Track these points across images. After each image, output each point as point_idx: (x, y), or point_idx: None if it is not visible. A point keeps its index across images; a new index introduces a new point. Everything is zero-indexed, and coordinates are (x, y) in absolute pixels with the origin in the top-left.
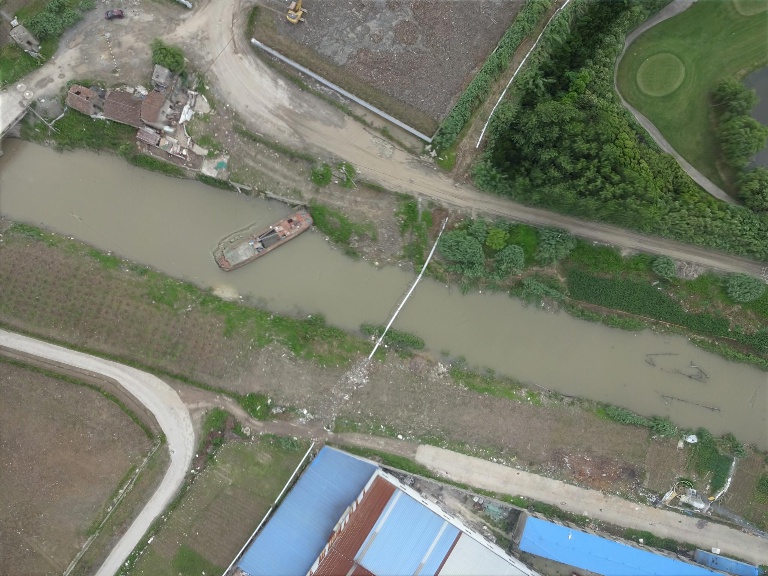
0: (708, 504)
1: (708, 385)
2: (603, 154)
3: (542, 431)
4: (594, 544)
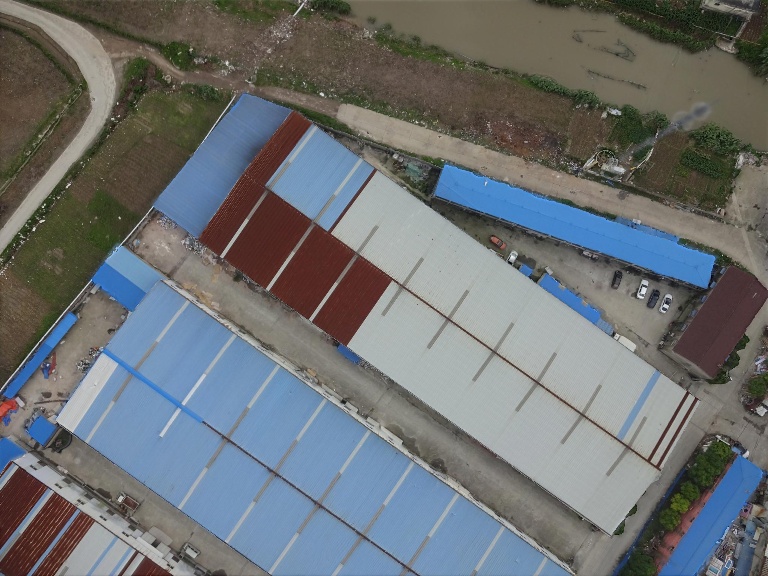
0: (630, 173)
1: (634, 62)
2: None
3: (465, 94)
4: (510, 192)
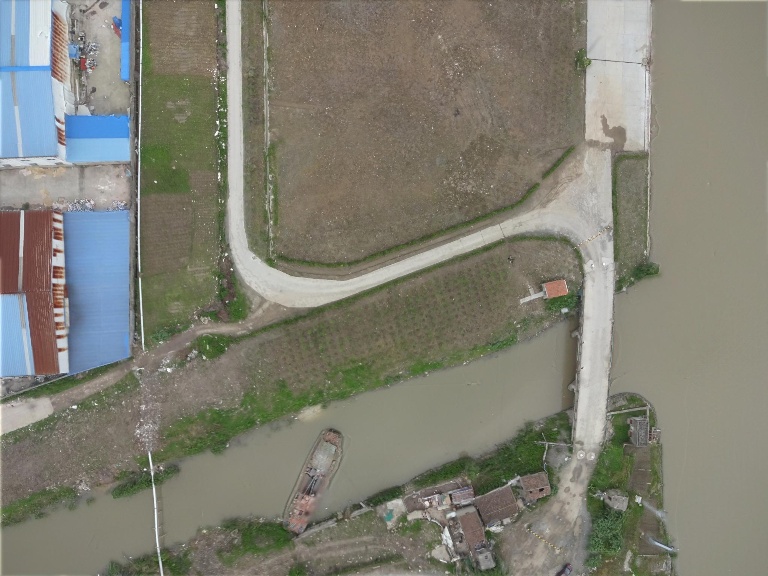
0: None
1: None
2: None
3: None
4: None
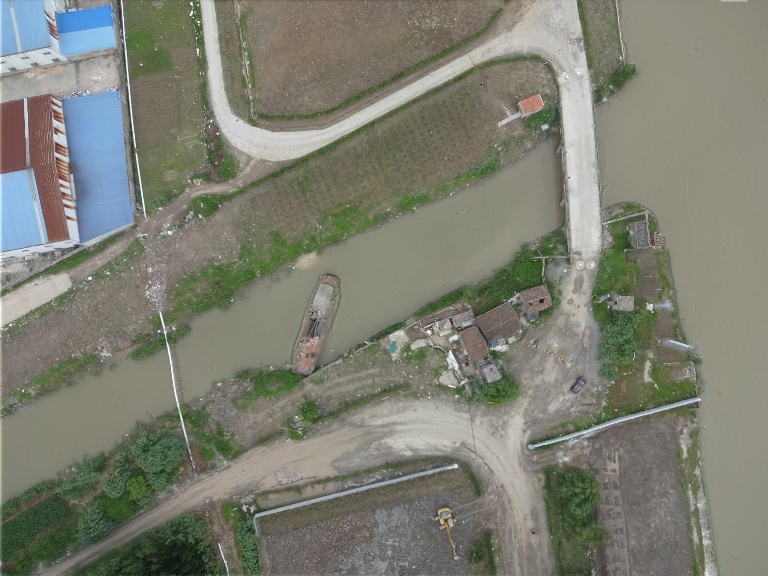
0: None
1: None
2: None
3: None
4: None
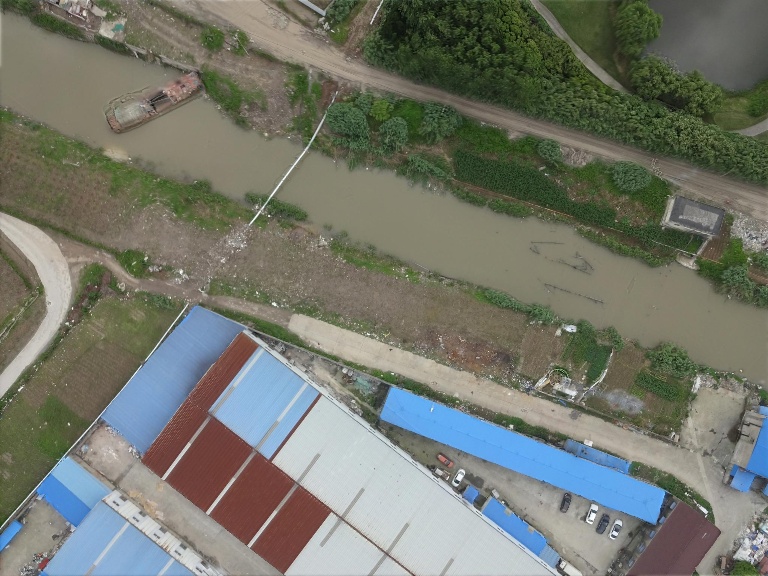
0: (582, 394)
1: (592, 276)
2: (483, 23)
3: (417, 308)
4: (456, 419)
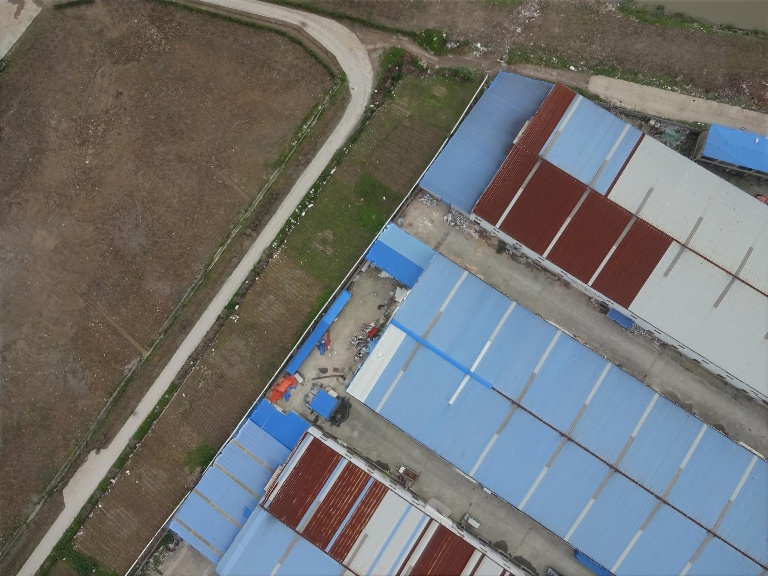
0: None
1: None
2: None
3: (718, 57)
4: None
